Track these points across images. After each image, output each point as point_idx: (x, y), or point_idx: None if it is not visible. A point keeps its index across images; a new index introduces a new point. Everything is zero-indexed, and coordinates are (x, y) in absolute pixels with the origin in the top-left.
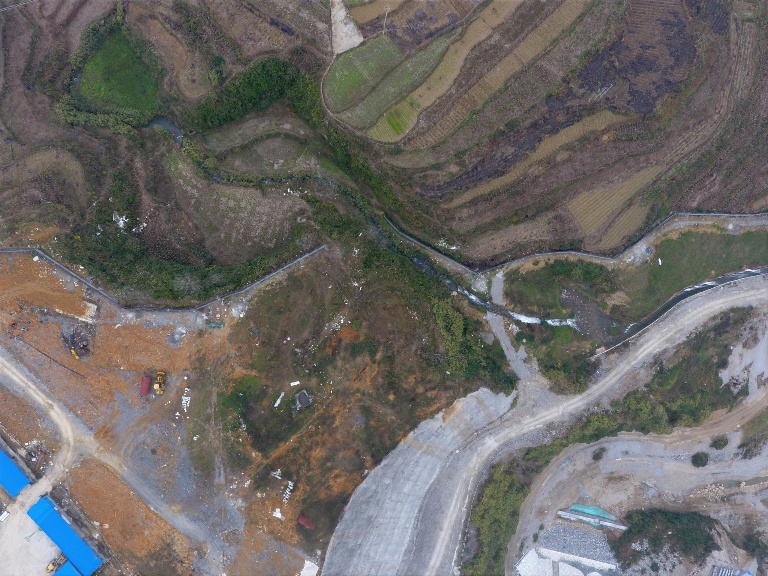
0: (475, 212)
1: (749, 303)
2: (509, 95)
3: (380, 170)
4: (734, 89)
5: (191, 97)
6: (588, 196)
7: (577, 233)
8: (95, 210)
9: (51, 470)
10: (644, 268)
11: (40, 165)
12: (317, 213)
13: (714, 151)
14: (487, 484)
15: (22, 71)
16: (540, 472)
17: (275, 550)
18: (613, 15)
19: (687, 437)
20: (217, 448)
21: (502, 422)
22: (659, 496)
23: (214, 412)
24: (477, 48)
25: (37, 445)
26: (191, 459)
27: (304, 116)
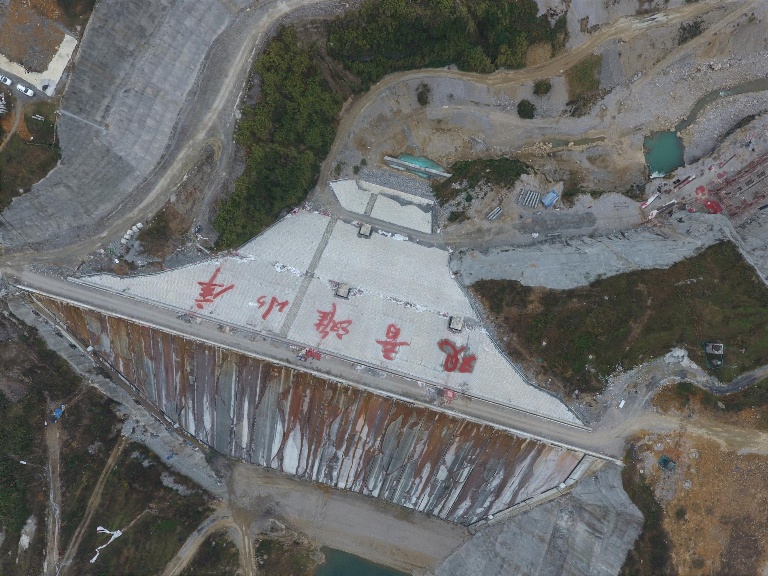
0: None
1: None
2: None
3: None
4: None
5: None
6: None
7: None
8: None
9: None
10: None
11: None
12: None
13: None
14: (274, 39)
15: None
16: (356, 92)
17: (37, 24)
18: None
19: (510, 79)
20: None
21: None
22: (487, 150)
23: None
24: None
25: None
26: None
27: None
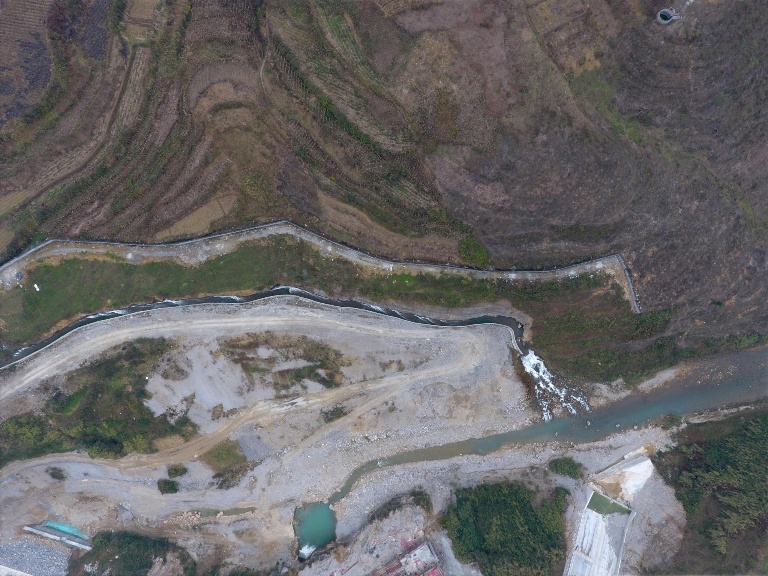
0: None
1: (161, 334)
2: None
3: None
4: (119, 116)
5: None
6: None
7: None
8: None
9: None
10: (16, 293)
11: None
12: None
13: (89, 178)
14: None
15: None
16: None
17: None
18: None
19: (143, 463)
20: None
21: None
22: (132, 519)
23: None
24: None
25: None
26: None
27: None
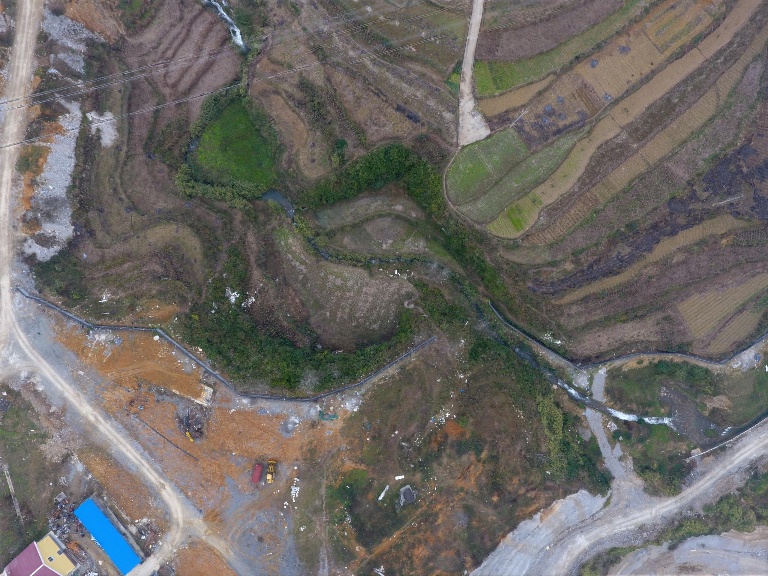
0: (585, 309)
1: None
2: (632, 195)
3: (495, 263)
4: None
5: (310, 177)
6: (700, 298)
7: (686, 336)
8: (212, 288)
9: (159, 549)
10: (750, 374)
11: (160, 238)
12: (424, 298)
13: None
14: None
15: (145, 140)
16: (617, 562)
17: None
18: (745, 119)
19: (767, 536)
20: (323, 540)
21: (594, 521)
22: None
23: (322, 504)
24: (603, 146)
25: (147, 523)
26: (296, 549)
27: (419, 201)
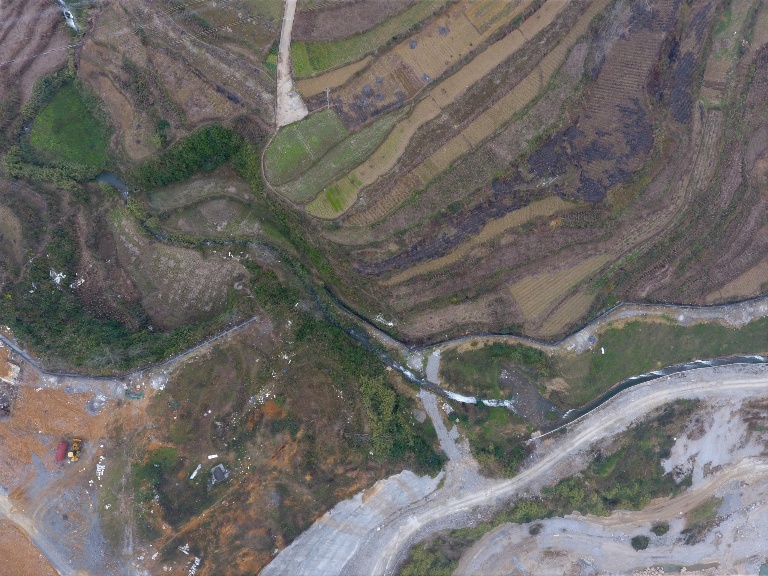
0: (413, 291)
1: (696, 395)
2: (454, 176)
3: (318, 244)
4: (694, 179)
5: (135, 158)
6: (532, 280)
7: (517, 318)
8: (30, 268)
9: None
10: (585, 356)
11: None
12: (255, 280)
13: (667, 242)
14: (405, 565)
15: None
16: (471, 546)
17: None
18: (568, 100)
19: (627, 520)
20: (127, 518)
21: (427, 502)
22: (596, 575)
23: (127, 482)
24: (425, 127)
25: None
26: (101, 527)
27: (248, 182)
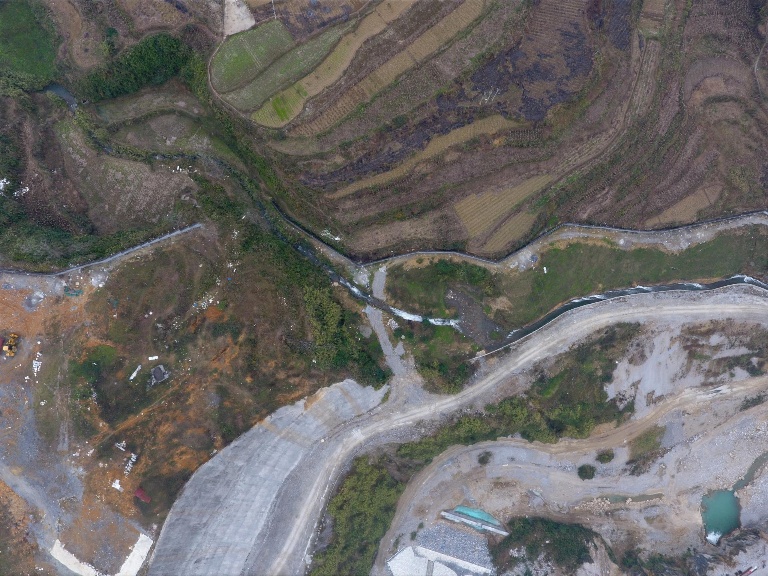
0: (359, 205)
1: (637, 319)
2: (399, 91)
3: (264, 154)
4: (633, 105)
5: (82, 66)
6: (476, 199)
7: (461, 234)
8: None
9: None
10: (528, 275)
11: None
12: (203, 192)
13: (606, 165)
14: (348, 475)
15: None
16: (420, 470)
17: (111, 521)
18: (510, 21)
19: (573, 448)
20: (64, 415)
21: (371, 416)
22: (544, 505)
23: (64, 379)
24: (370, 42)
25: None
26: (36, 423)
27: None
